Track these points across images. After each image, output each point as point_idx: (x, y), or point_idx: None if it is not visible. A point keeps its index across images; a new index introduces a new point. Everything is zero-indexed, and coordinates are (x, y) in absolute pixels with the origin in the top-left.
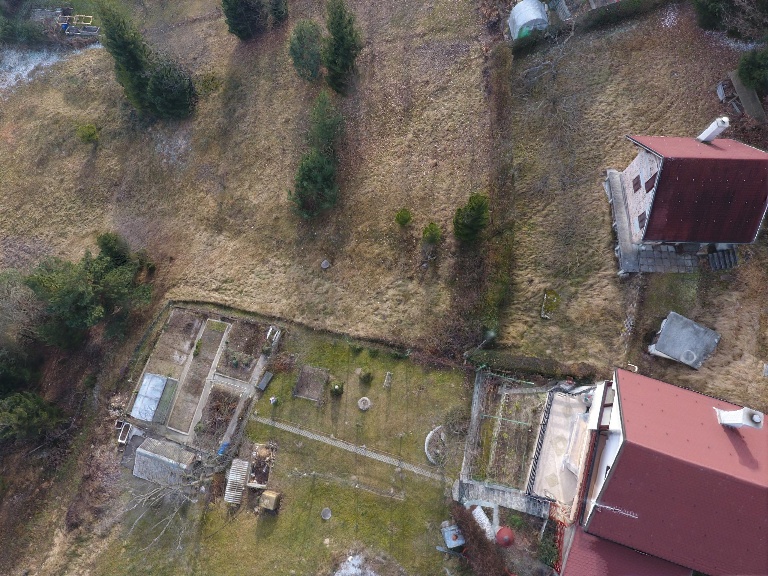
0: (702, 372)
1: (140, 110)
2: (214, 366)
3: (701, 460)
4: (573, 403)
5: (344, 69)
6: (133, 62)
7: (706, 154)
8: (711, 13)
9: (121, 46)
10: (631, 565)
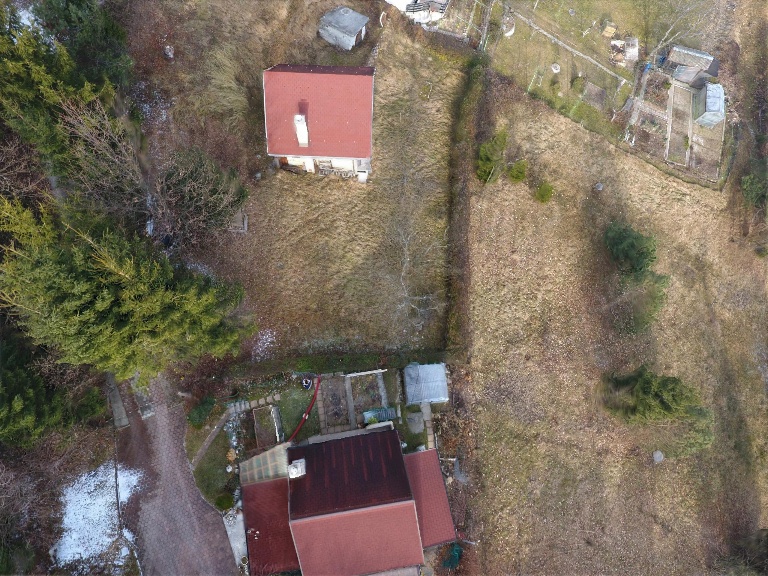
0: (339, 2)
1: None
2: (669, 128)
3: None
4: None
5: None
6: None
7: (328, 86)
8: None
9: None
10: None
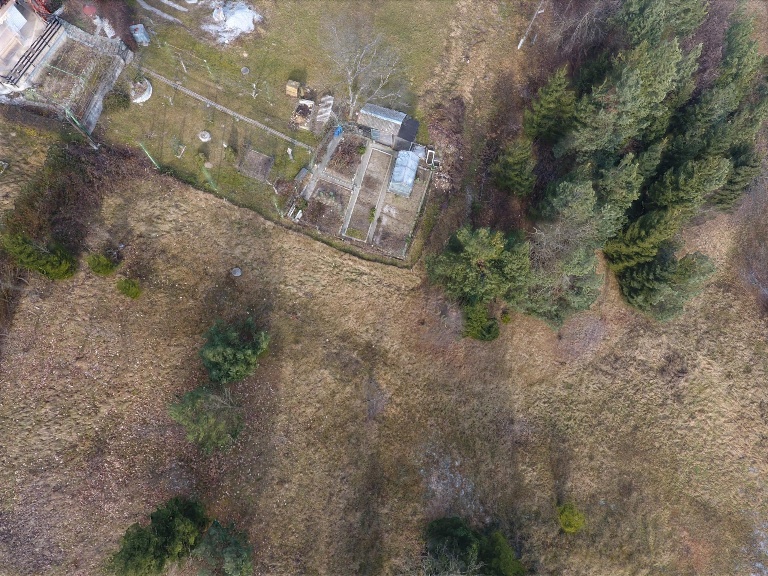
0: None
1: None
2: (355, 198)
3: None
4: (0, 78)
5: None
6: None
7: None
8: None
9: None
10: None
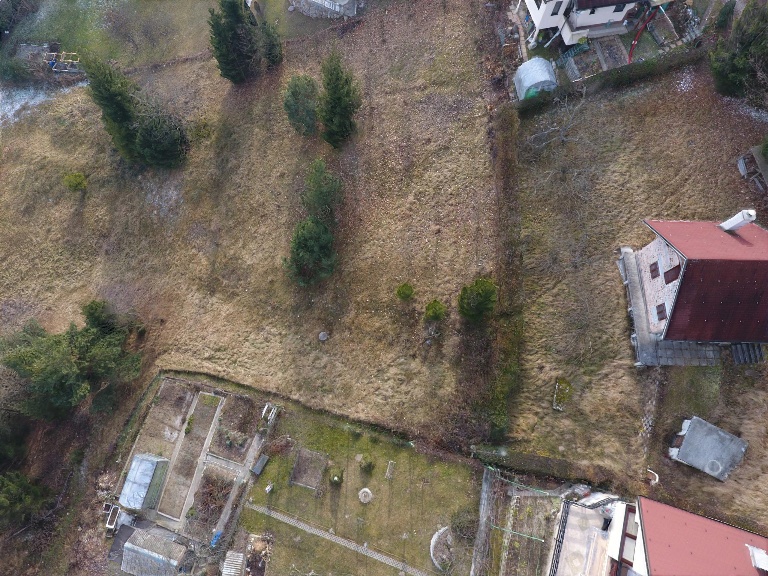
0: (728, 485)
1: (129, 160)
2: (207, 445)
3: None
4: (589, 514)
5: (341, 127)
6: (121, 113)
7: (732, 253)
8: (731, 81)
9: (108, 98)
10: None
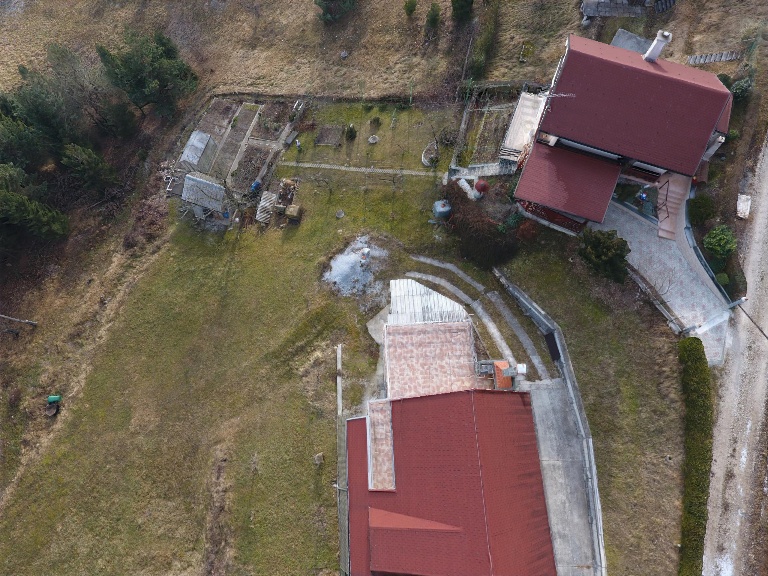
0: None
1: None
2: (248, 134)
3: (624, 63)
4: (540, 100)
5: None
6: None
7: None
8: None
9: None
10: (574, 168)
